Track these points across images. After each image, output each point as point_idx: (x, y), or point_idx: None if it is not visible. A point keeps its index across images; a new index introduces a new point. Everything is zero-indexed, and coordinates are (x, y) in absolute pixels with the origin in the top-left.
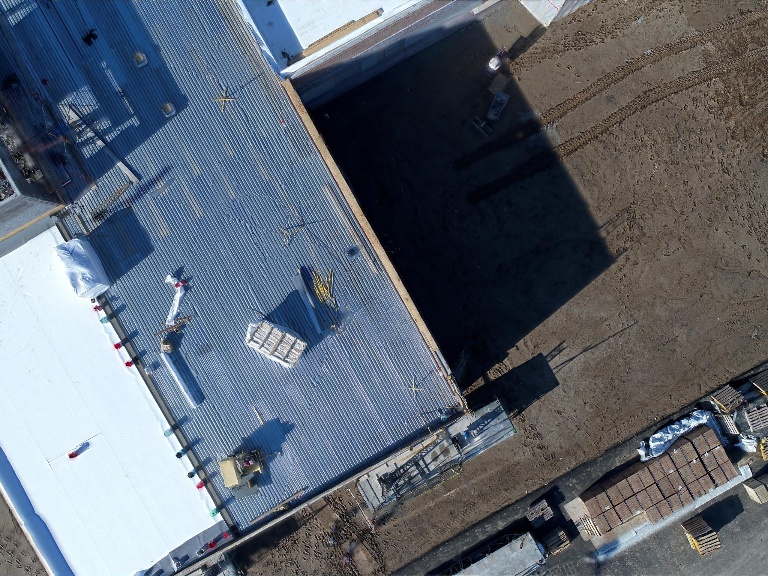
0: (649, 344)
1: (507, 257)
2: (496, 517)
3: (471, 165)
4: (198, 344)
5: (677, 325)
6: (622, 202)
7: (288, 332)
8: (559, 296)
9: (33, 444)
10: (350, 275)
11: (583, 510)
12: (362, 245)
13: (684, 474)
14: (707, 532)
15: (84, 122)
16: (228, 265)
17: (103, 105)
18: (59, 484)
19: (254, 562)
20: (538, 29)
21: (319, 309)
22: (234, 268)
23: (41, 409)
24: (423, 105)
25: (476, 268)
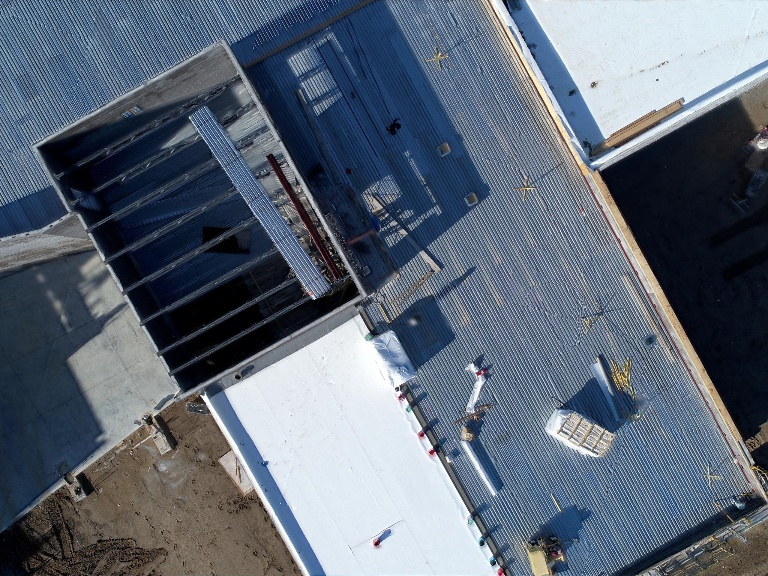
0: None
1: (760, 332)
2: None
3: (727, 241)
4: (497, 431)
5: None
6: None
7: (597, 423)
8: None
9: (336, 531)
10: (647, 363)
11: None
12: (659, 333)
13: None
14: None
15: (387, 211)
16: (527, 353)
17: (406, 194)
18: (361, 570)
19: None
20: None
21: (617, 397)
22: (533, 356)
23: (344, 496)
24: (680, 181)
25: (730, 343)
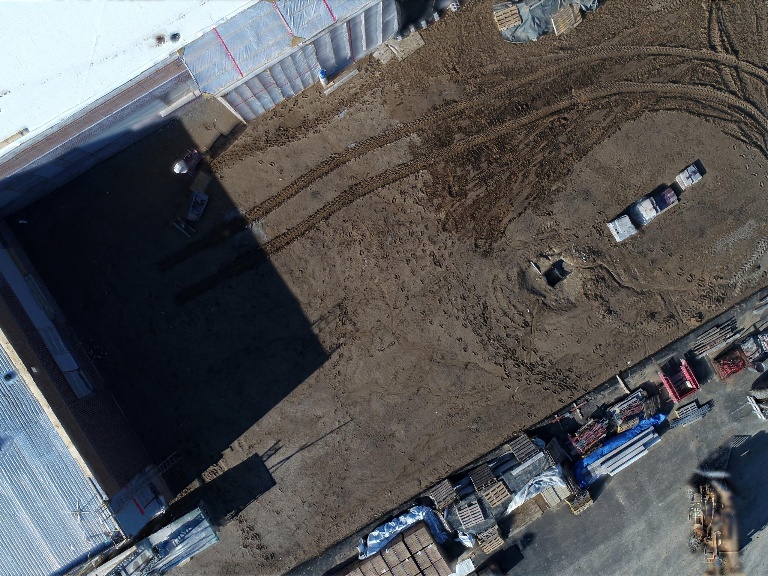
0: (366, 440)
1: (218, 358)
2: None
3: (176, 266)
4: None
5: (394, 420)
6: (333, 298)
7: None
8: (272, 395)
9: None
10: (8, 400)
11: None
12: None
13: (397, 573)
14: None
15: None
16: None
17: None
18: None
19: None
20: (238, 126)
21: None
22: None
23: None
24: (124, 207)
25: (186, 370)
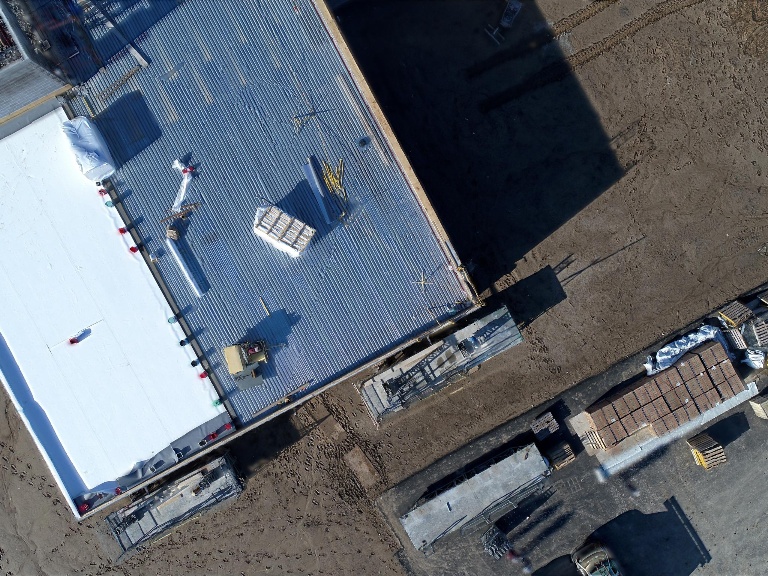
0: (658, 259)
1: (517, 167)
2: (501, 430)
3: (482, 73)
4: (204, 232)
5: (686, 240)
6: (633, 115)
7: (297, 218)
8: (568, 208)
9: (33, 329)
10: (360, 166)
11: (588, 424)
12: (373, 135)
13: (691, 387)
14: (713, 446)
15: (93, 2)
16: (237, 152)
17: None
18: (59, 371)
19: (255, 472)
20: None
21: (328, 199)
22: (243, 155)
23: (42, 294)
24: (435, 11)
25: (485, 178)
